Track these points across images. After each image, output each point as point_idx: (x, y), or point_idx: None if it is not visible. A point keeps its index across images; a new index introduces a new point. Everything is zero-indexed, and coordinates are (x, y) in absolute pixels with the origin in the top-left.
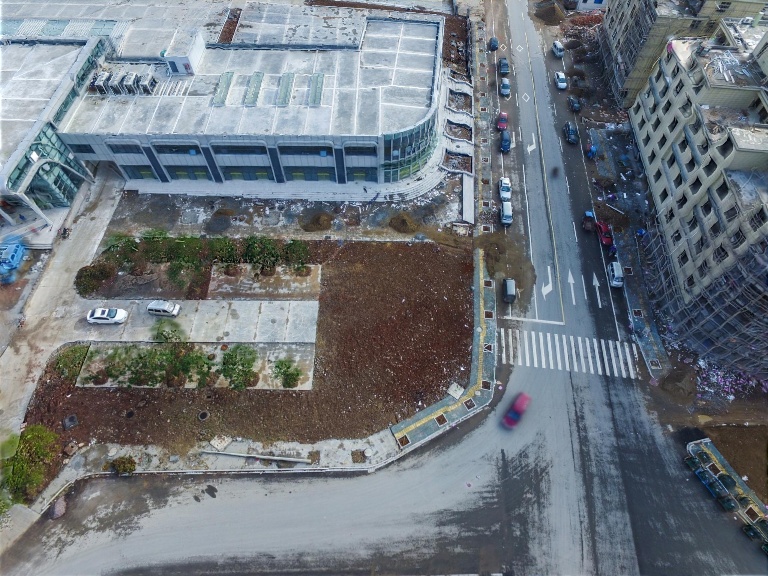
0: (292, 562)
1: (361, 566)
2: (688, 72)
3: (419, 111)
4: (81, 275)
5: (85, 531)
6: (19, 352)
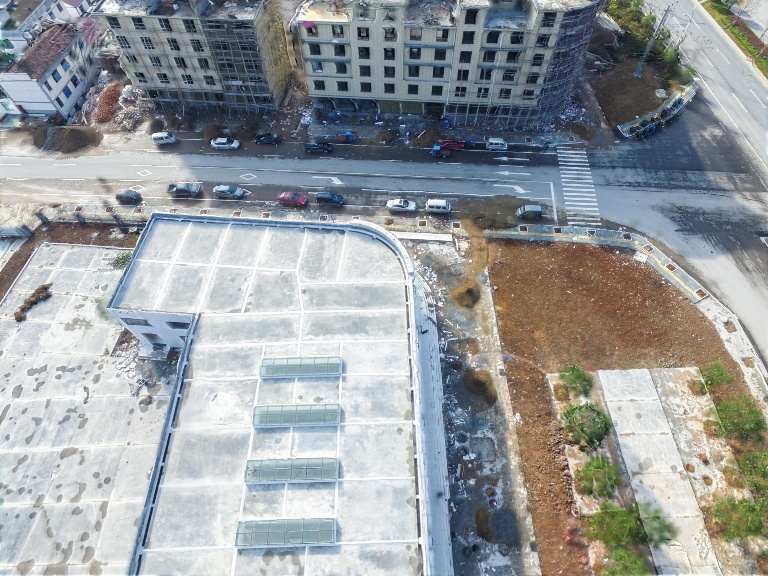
0: None
1: None
2: (356, 20)
3: (353, 241)
4: None
5: None
6: None
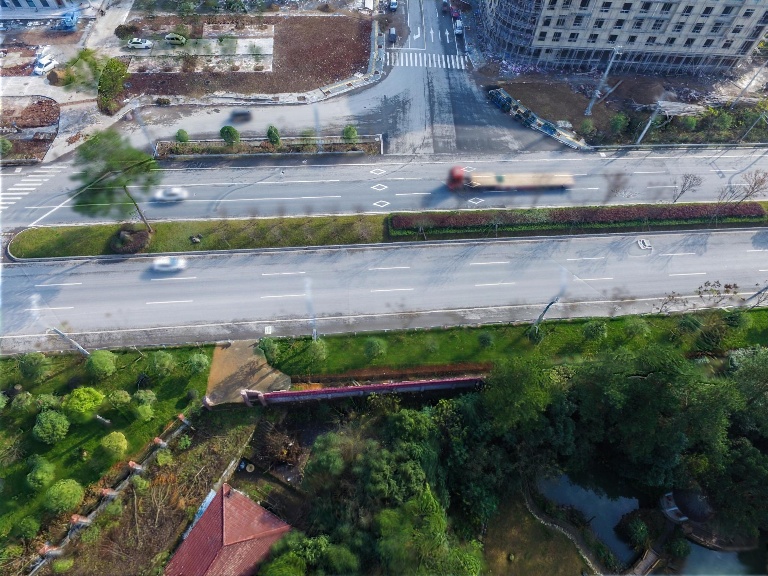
0: (266, 133)
1: (304, 134)
2: None
3: None
4: (118, 28)
5: (146, 125)
6: (87, 61)
